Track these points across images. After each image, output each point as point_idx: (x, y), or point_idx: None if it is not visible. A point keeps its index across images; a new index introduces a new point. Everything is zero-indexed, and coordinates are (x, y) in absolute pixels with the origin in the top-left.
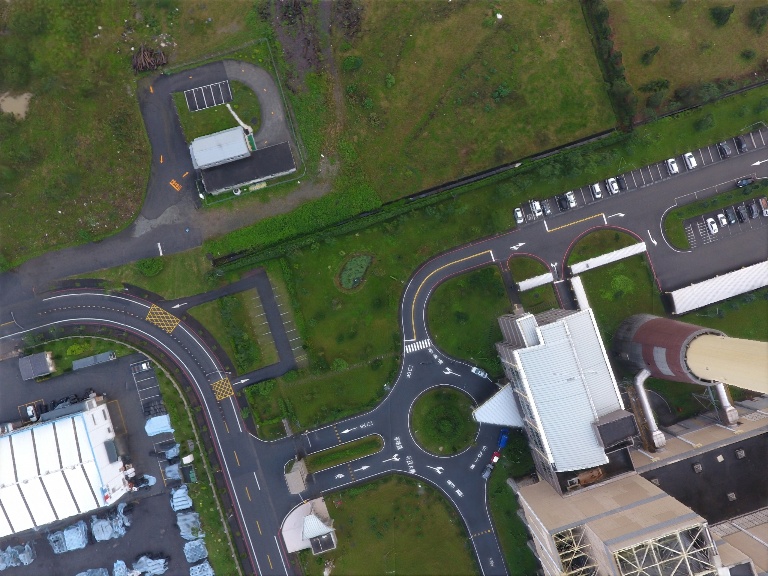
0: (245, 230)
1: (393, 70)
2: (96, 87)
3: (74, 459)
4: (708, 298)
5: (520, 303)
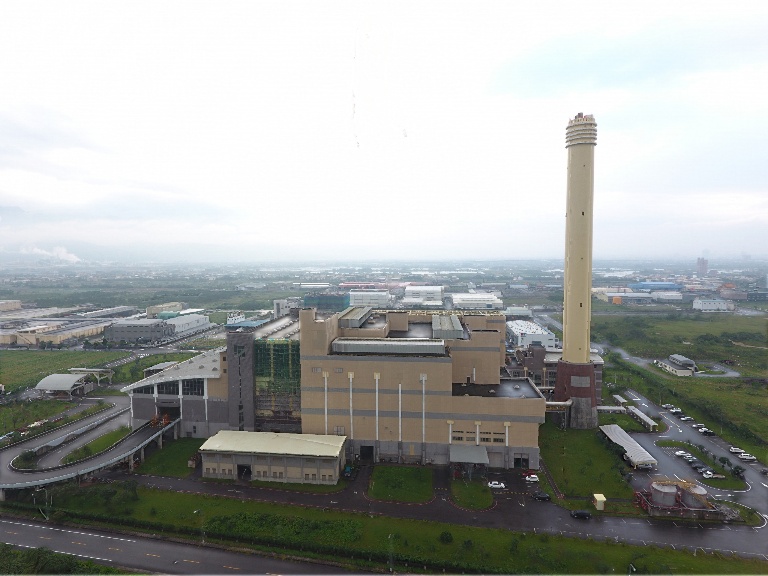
0: (639, 366)
1: (761, 395)
2: (704, 352)
3: (537, 333)
4: (614, 435)
5: (604, 400)
